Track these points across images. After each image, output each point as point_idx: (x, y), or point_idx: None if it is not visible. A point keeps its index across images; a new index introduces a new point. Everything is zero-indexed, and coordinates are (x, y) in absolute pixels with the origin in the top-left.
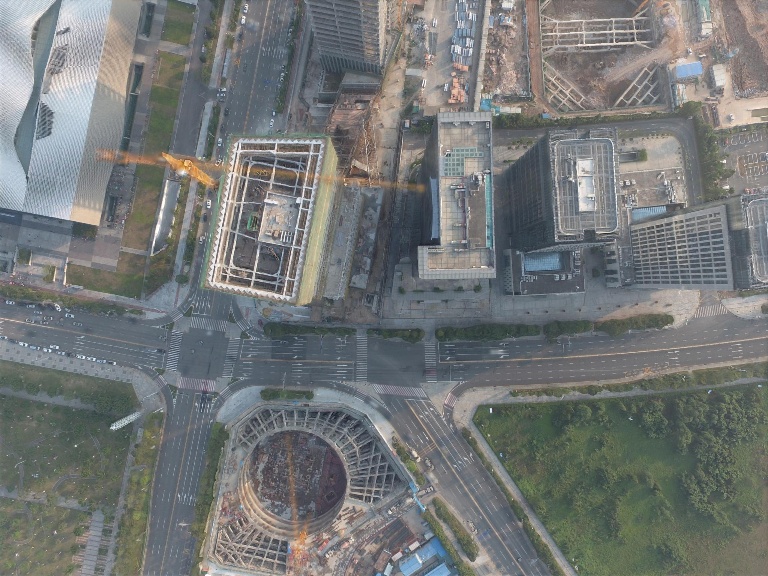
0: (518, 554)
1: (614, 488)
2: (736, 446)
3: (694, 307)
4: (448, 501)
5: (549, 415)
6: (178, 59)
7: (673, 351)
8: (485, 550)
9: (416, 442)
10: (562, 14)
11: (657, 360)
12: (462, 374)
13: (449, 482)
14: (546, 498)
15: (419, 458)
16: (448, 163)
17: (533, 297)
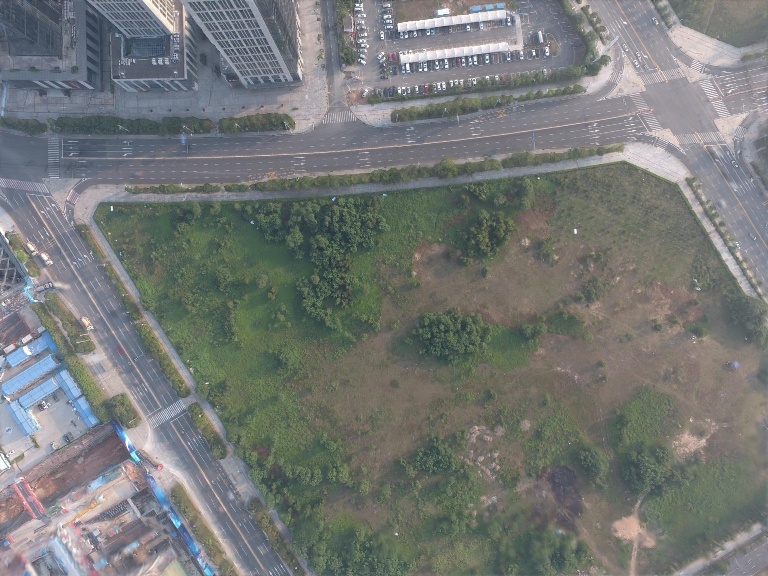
0: (135, 354)
1: (233, 292)
2: (352, 252)
3: (322, 112)
4: (66, 298)
5: (169, 215)
6: None
7: (299, 156)
8: (102, 348)
9: (36, 237)
10: None
11: (282, 165)
12: (85, 171)
13: (68, 279)
14: (163, 298)
15: (35, 252)
16: None
17: (150, 91)
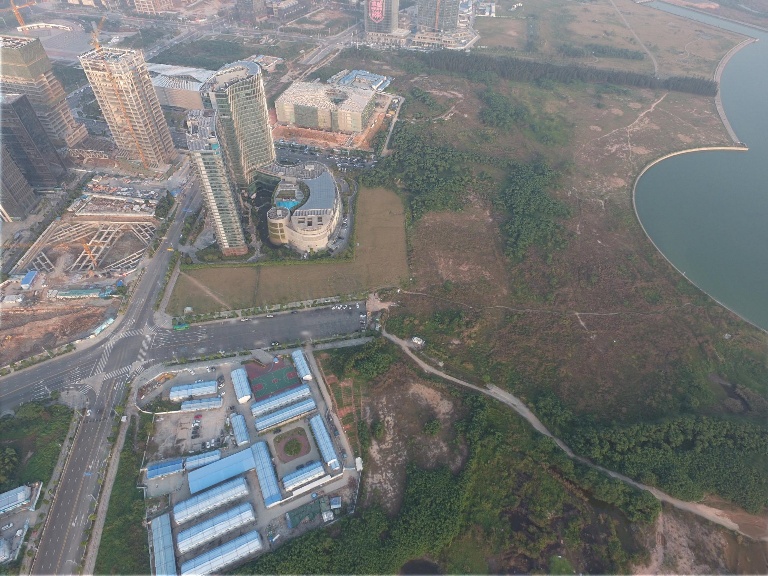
0: None
1: None
2: None
3: None
4: None
5: None
6: (181, 119)
7: None
8: None
9: None
10: (132, 249)
11: None
12: None
13: None
14: None
15: None
16: (3, 97)
17: None
